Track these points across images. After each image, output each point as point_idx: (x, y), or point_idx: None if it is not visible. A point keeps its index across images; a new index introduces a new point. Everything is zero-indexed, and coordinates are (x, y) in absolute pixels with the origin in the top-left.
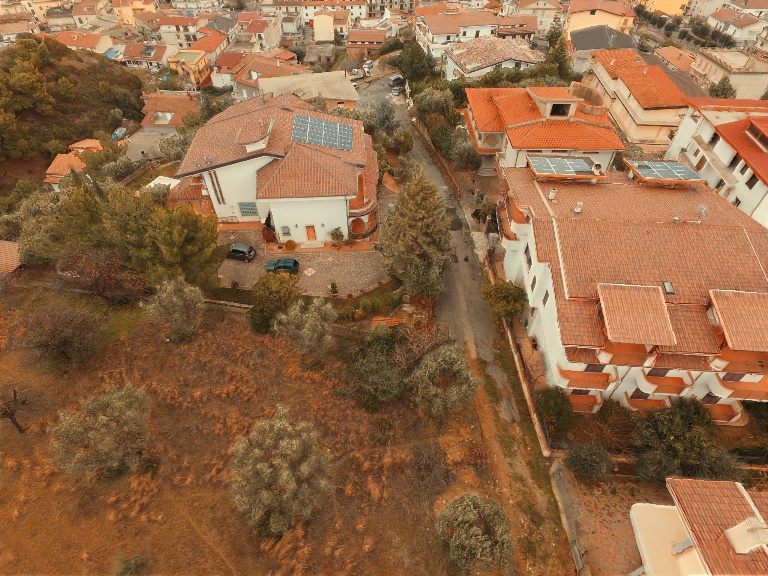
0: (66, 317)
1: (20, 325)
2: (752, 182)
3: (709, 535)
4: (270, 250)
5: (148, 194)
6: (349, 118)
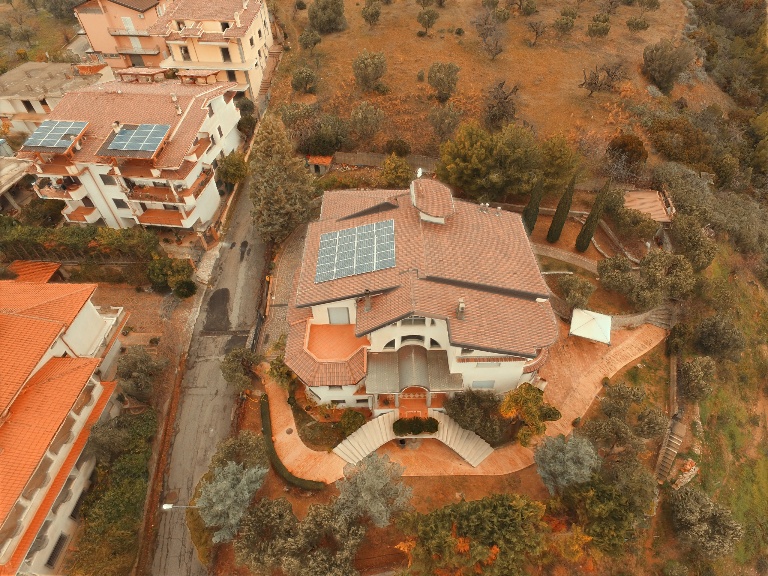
0: None
1: None
2: None
3: None
4: None
5: (499, 141)
6: (316, 303)
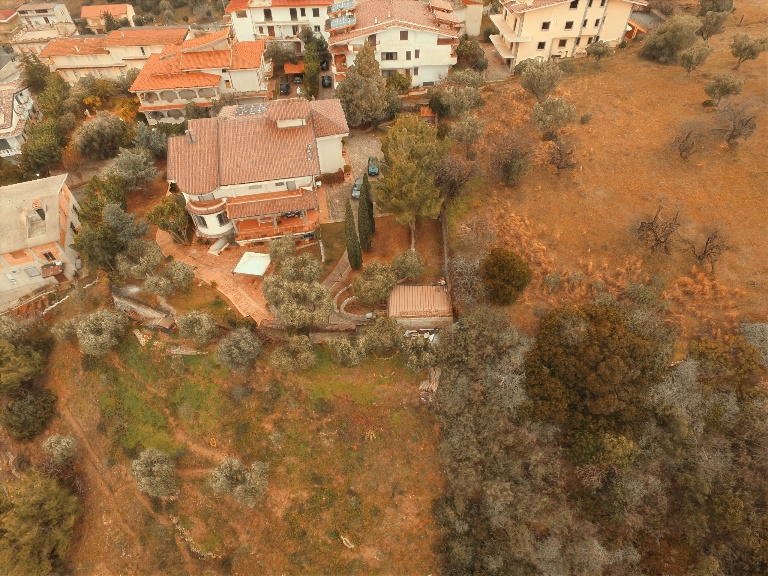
0: (503, 150)
1: (495, 216)
2: (315, 14)
3: (530, 6)
4: (351, 180)
5: None
6: (222, 108)
